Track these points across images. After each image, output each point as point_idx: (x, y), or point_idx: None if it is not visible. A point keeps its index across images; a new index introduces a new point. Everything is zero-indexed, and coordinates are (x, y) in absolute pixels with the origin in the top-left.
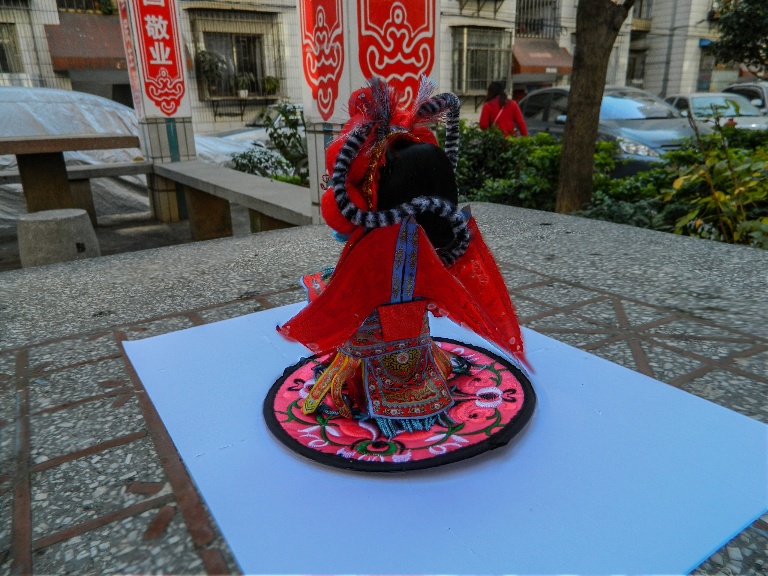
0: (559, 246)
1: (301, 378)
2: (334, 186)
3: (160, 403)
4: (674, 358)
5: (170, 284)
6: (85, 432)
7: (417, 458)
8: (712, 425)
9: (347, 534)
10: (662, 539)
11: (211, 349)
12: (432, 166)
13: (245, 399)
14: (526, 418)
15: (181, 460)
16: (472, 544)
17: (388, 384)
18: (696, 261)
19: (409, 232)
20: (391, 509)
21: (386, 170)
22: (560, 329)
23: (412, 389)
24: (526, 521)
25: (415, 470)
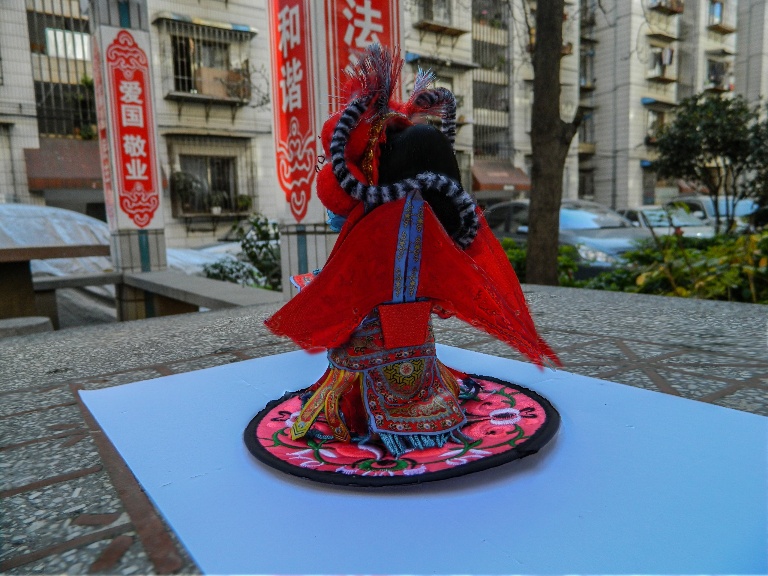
0: (546, 306)
1: (287, 410)
2: (332, 156)
3: (120, 440)
4: (696, 380)
5: (137, 345)
6: (25, 470)
7: (434, 470)
8: (761, 432)
9: (356, 552)
10: (748, 537)
11: (181, 393)
12: (436, 144)
13: (221, 432)
14: (553, 429)
15: (143, 490)
16: (517, 554)
17: (390, 400)
18: (688, 312)
19: (414, 212)
20: (408, 524)
21: (387, 147)
22: (567, 363)
23: (419, 404)
24: (577, 528)
25: (433, 481)
